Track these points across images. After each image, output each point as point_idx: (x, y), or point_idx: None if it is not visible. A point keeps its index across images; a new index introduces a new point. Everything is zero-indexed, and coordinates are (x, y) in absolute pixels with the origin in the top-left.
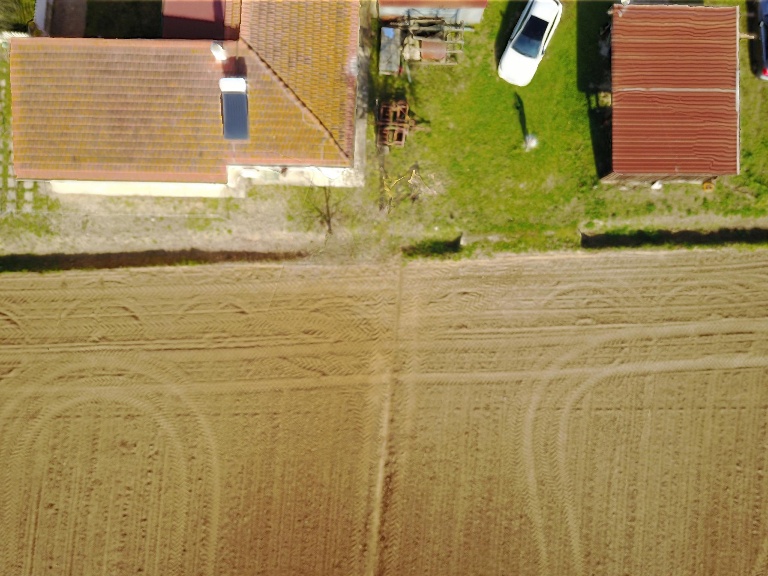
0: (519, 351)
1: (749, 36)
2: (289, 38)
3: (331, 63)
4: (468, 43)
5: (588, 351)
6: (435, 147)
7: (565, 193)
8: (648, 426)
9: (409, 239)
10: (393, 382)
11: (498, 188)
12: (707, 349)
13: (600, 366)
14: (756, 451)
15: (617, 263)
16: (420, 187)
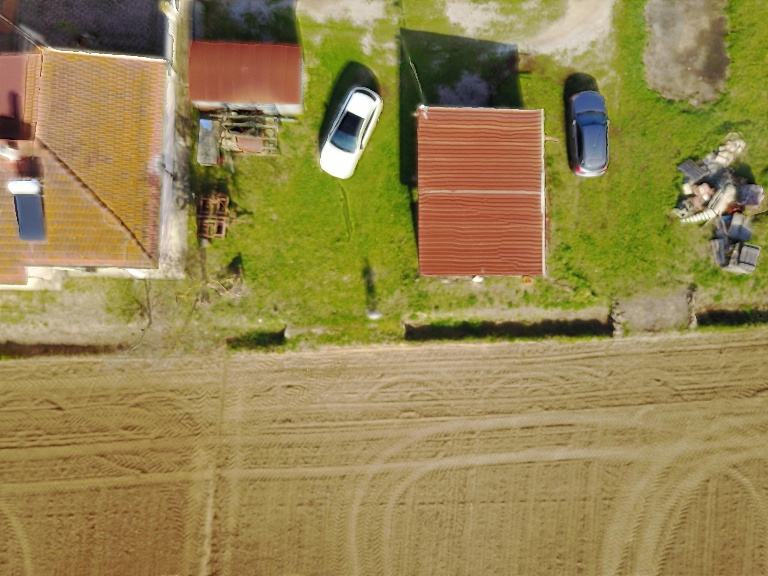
0: (342, 445)
1: (554, 138)
2: (89, 137)
3: (134, 162)
4: (292, 134)
5: (411, 445)
6: (259, 238)
7: (388, 285)
8: (470, 520)
9: (234, 331)
10: (216, 478)
11: (322, 280)
12: (528, 442)
13: (423, 460)
14: (575, 544)
15: (441, 355)
16: (219, 292)
